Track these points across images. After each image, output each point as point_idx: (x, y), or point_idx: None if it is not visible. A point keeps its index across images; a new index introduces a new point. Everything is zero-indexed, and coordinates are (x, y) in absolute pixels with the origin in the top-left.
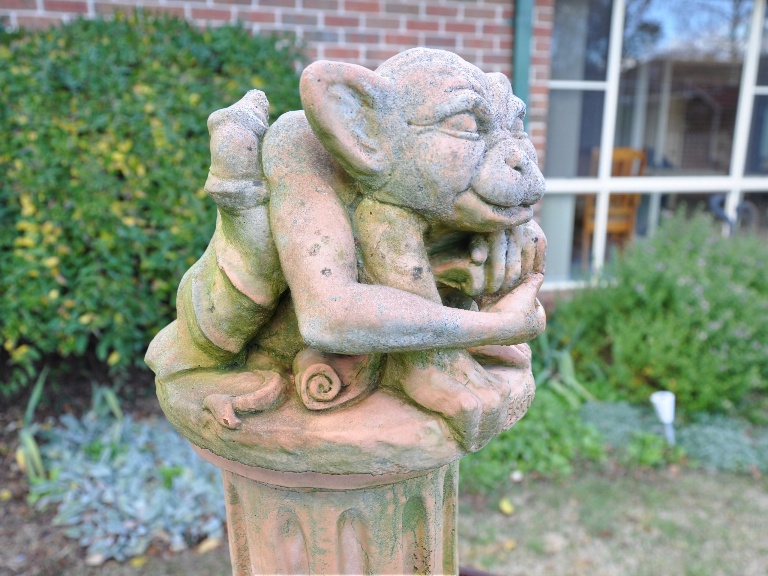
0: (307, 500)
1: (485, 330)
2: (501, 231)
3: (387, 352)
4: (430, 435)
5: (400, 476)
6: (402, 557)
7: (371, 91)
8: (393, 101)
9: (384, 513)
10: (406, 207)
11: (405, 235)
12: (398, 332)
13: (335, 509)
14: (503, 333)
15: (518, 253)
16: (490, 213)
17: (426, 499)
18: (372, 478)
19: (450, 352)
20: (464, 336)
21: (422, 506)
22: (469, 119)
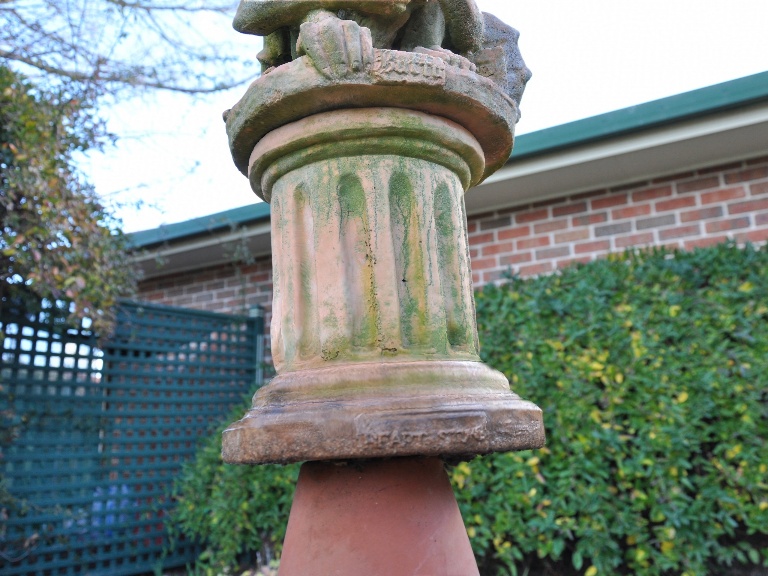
0: (281, 185)
1: None
2: None
3: (268, 15)
4: None
5: (311, 131)
6: (338, 224)
7: None
8: None
9: (321, 182)
10: None
11: None
12: None
13: None
14: None
15: None
16: None
17: (363, 180)
18: (293, 134)
19: (315, 12)
20: None
21: (362, 189)
22: None
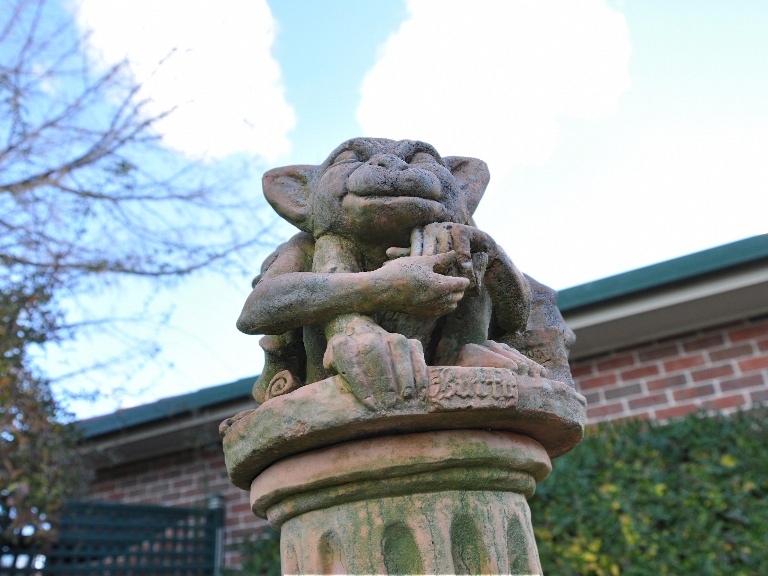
0: (298, 527)
1: (356, 281)
2: (415, 230)
3: (284, 318)
4: (326, 389)
5: (344, 468)
6: None
7: (303, 173)
8: (315, 172)
9: (357, 535)
10: (328, 232)
11: (328, 251)
12: (280, 293)
13: (316, 532)
14: (377, 282)
15: (431, 241)
16: (362, 201)
17: (415, 532)
18: (318, 470)
19: (347, 317)
20: (337, 289)
21: (415, 544)
22: (347, 153)
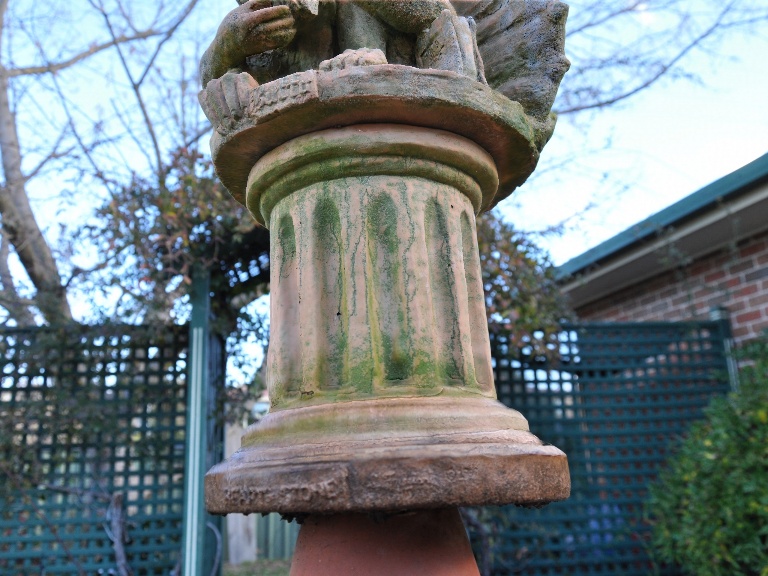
0: None
1: None
2: None
3: None
4: None
5: None
6: (279, 268)
7: None
8: None
9: None
10: None
11: None
12: None
13: None
14: None
15: None
16: None
17: None
18: None
19: None
20: None
21: None
22: None
